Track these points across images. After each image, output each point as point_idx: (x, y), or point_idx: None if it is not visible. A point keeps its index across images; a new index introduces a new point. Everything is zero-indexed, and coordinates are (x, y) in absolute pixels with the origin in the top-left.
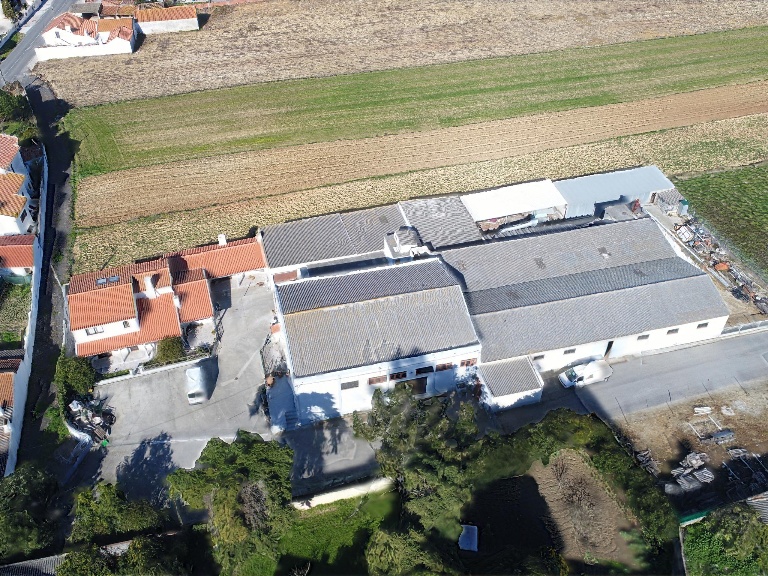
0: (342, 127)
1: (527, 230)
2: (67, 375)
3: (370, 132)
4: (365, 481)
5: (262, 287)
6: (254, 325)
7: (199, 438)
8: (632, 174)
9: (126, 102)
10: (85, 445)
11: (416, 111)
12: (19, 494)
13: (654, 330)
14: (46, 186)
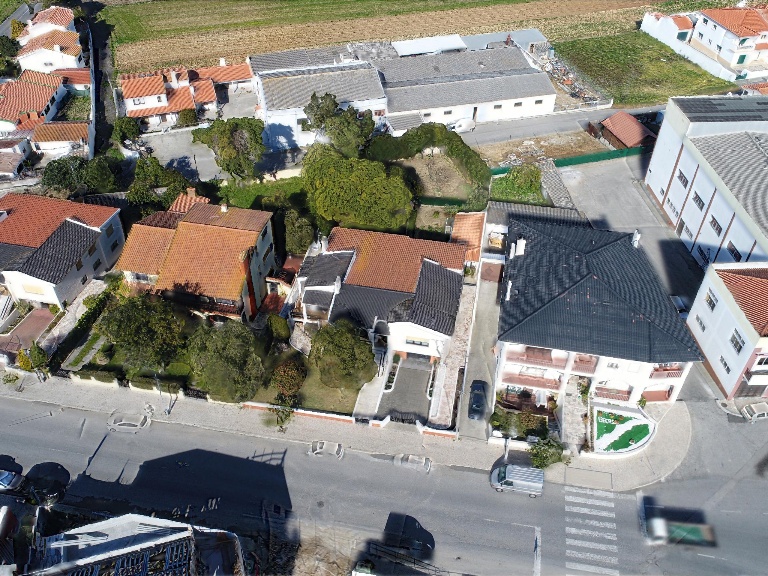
0: (314, 16)
1: None
2: (122, 126)
3: (335, 19)
4: None
5: (250, 93)
6: (244, 111)
7: (208, 158)
8: (518, 33)
9: (148, 2)
10: (136, 158)
11: (372, 7)
12: None
13: (504, 101)
14: (92, 49)
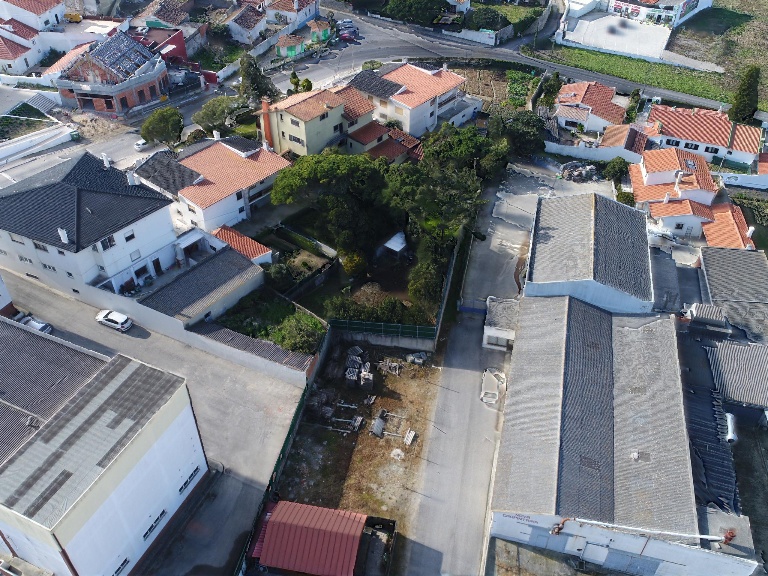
0: None
1: (725, 436)
2: None
3: None
4: (469, 244)
5: None
6: None
7: None
8: None
9: None
10: None
11: None
12: (520, 130)
13: None
14: None
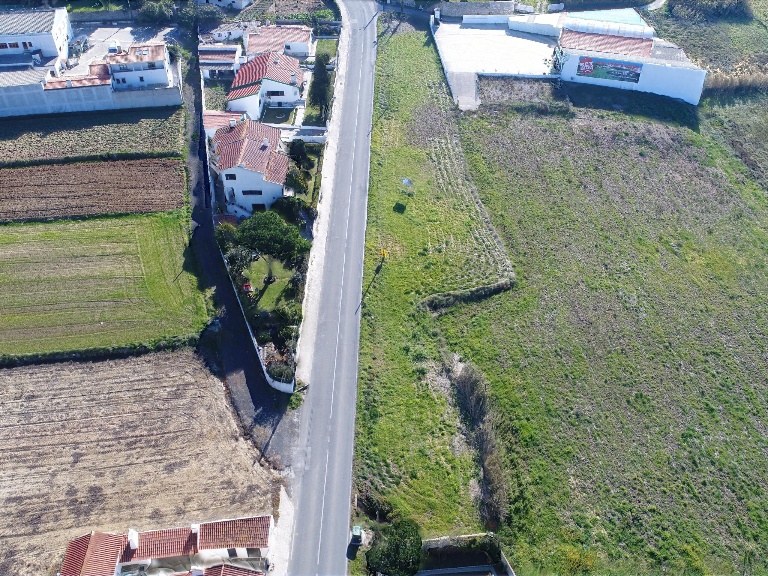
0: None
1: None
2: None
3: None
4: None
5: None
6: None
7: (121, 41)
8: None
9: (119, 345)
10: None
11: None
12: None
13: None
14: None
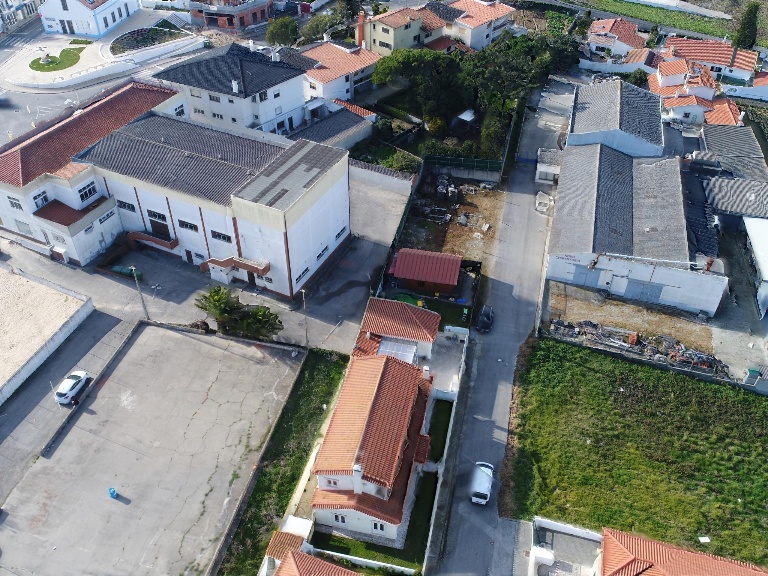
0: None
1: None
2: None
3: None
4: (521, 122)
5: None
6: None
7: None
8: None
9: None
10: None
11: None
12: None
13: None
14: None
